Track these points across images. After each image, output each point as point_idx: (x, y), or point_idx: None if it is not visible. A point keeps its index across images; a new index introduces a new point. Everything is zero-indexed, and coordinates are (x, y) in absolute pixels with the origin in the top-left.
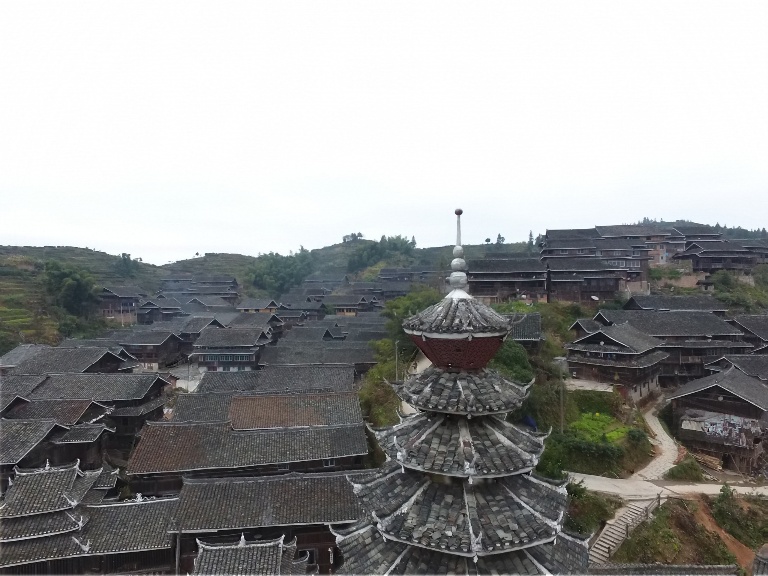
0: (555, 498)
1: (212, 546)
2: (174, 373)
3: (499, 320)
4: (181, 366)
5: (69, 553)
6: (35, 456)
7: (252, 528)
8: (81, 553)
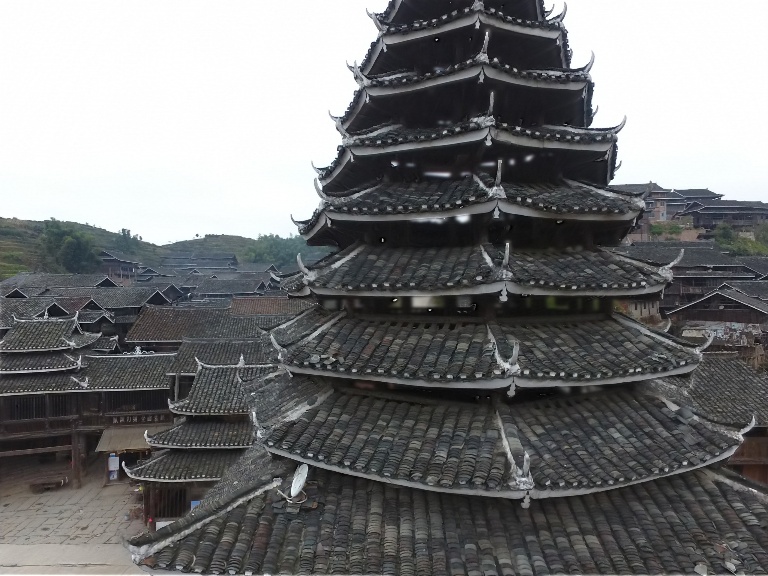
0: None
1: (211, 365)
2: None
3: None
4: None
5: (67, 388)
6: None
7: None
8: (80, 388)
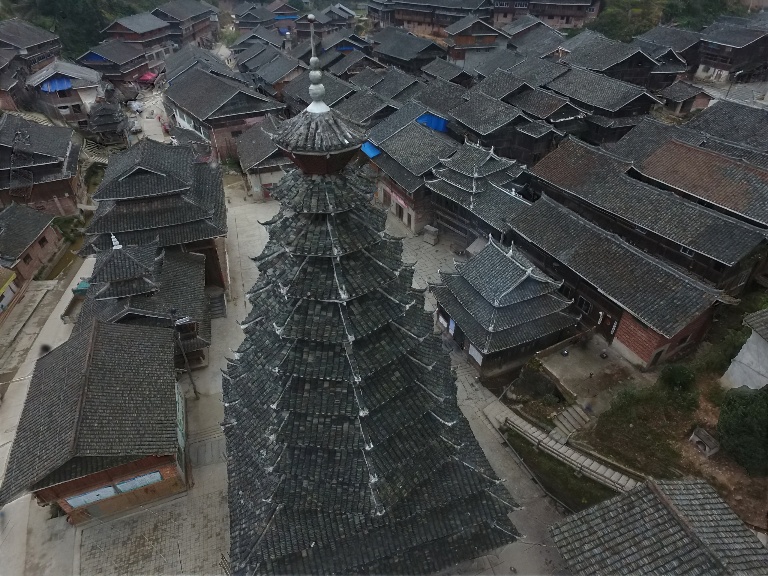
0: (326, 290)
1: (495, 244)
2: (709, 90)
3: (292, 139)
4: (722, 83)
5: (464, 204)
6: (498, 134)
7: (551, 255)
8: (468, 208)
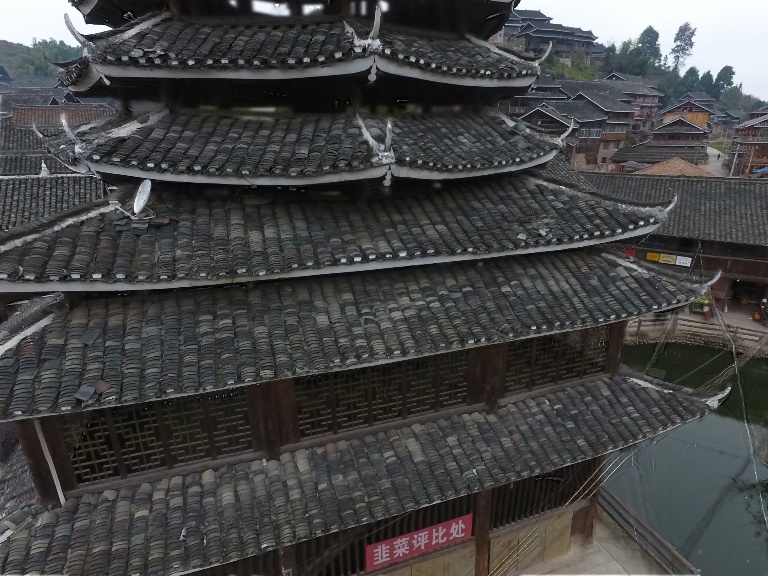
0: None
1: (0, 175)
2: None
3: None
4: None
5: None
6: None
7: None
8: None
